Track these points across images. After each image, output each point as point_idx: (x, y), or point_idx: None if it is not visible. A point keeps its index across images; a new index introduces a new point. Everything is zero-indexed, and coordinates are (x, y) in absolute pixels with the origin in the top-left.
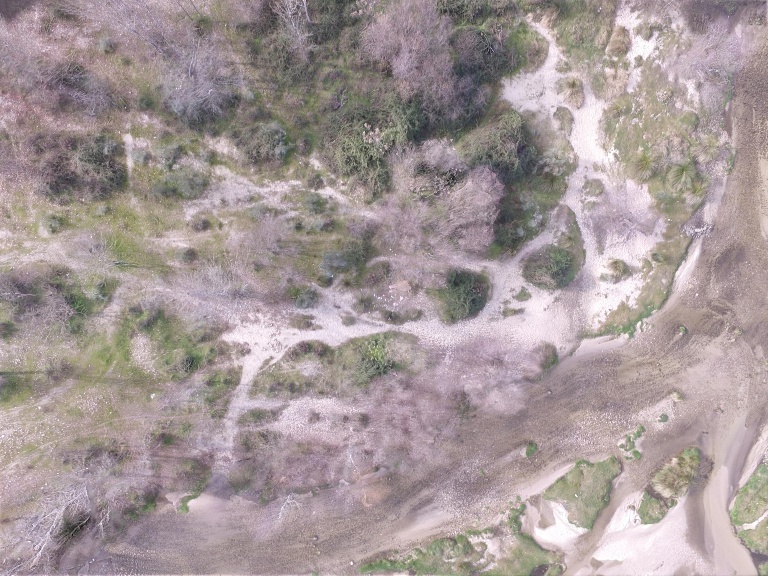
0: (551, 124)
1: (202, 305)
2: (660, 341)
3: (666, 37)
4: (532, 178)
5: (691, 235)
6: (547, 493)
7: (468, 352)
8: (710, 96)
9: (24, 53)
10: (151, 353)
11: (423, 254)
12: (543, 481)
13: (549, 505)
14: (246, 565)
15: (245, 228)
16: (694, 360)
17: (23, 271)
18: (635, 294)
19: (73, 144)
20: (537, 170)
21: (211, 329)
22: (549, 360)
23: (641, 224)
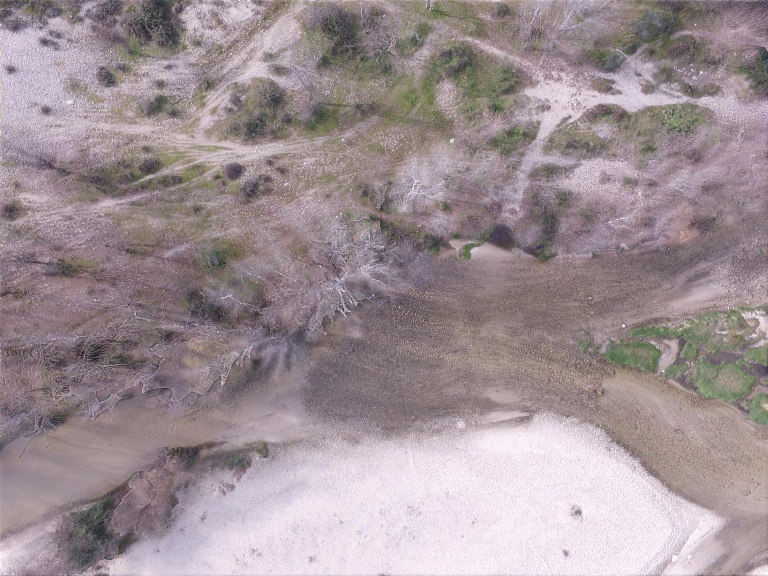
0: None
1: (508, 59)
2: None
3: None
4: None
5: None
6: None
7: (760, 132)
8: None
9: None
10: (456, 99)
11: None
12: None
13: None
14: (520, 317)
15: None
16: None
17: (342, 8)
18: None
19: None
20: None
21: (516, 82)
22: None
23: None
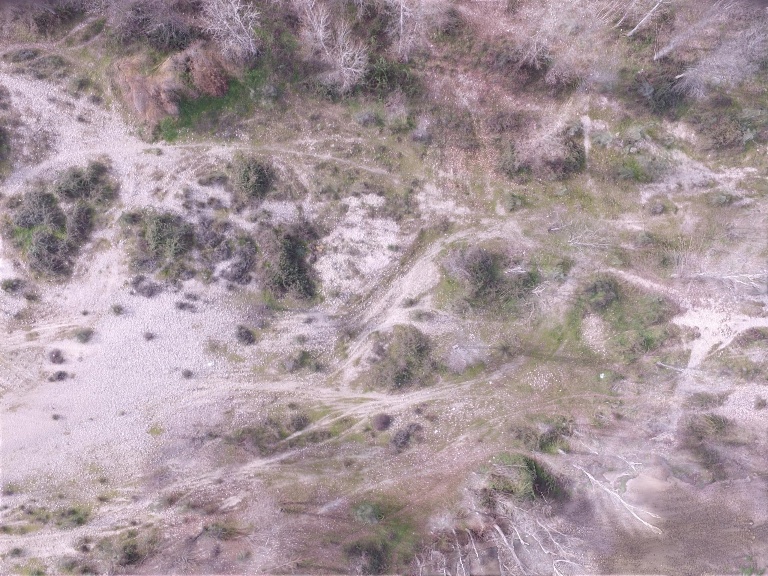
0: None
1: (654, 288)
2: None
3: None
4: None
5: None
6: None
7: None
8: None
9: (487, 32)
10: (603, 333)
11: None
12: None
13: None
14: (681, 546)
15: (700, 213)
16: None
17: (481, 247)
18: None
19: (537, 124)
20: None
21: (664, 312)
22: None
23: None
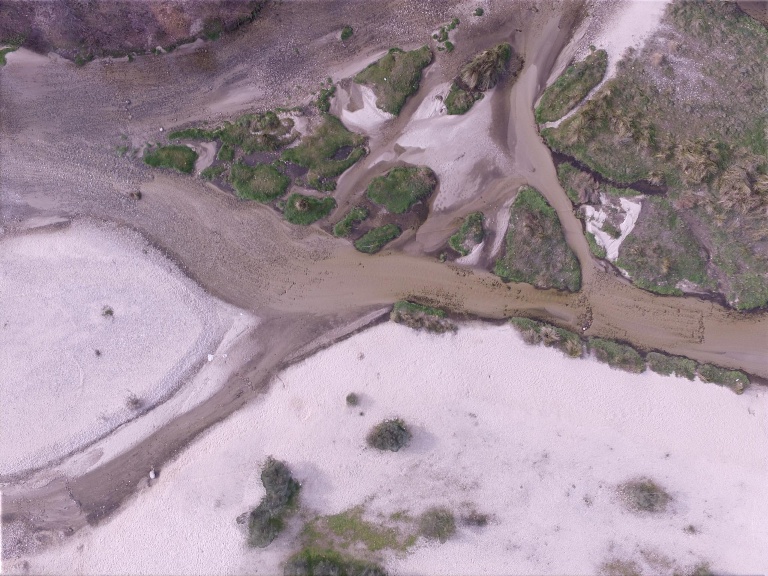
0: None
1: None
2: None
3: None
4: None
5: None
6: (358, 76)
7: None
8: None
9: None
10: None
11: None
12: (355, 65)
13: (359, 89)
14: (58, 122)
15: None
16: None
17: None
18: None
19: None
20: None
21: None
22: None
23: None
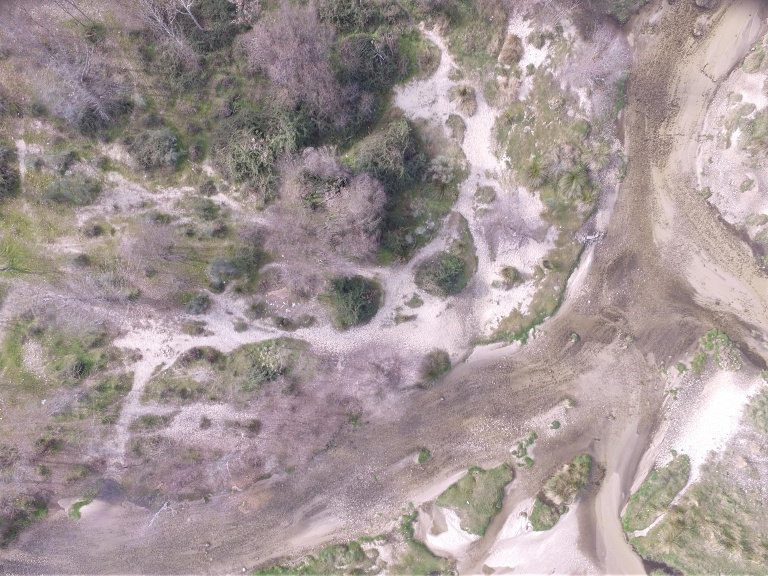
0: (443, 131)
1: (94, 311)
2: (552, 348)
3: (558, 46)
4: (423, 185)
5: (583, 242)
6: (439, 500)
7: (360, 358)
8: (602, 104)
9: None
10: (42, 359)
11: (315, 261)
12: (436, 488)
13: (441, 512)
14: (138, 572)
15: (137, 234)
16: (586, 367)
17: None
18: (527, 301)
19: None
20: (427, 177)
21: (102, 335)
22: (441, 367)
23: (533, 231)
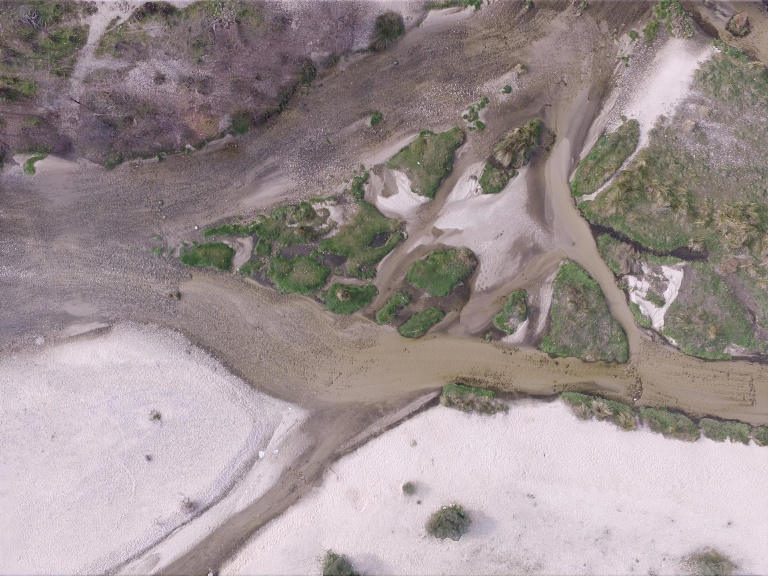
0: None
1: None
2: (506, 14)
3: None
4: None
5: None
6: (390, 161)
7: (315, 19)
8: None
9: None
10: None
11: None
12: (387, 151)
13: (392, 174)
14: (92, 227)
15: None
16: (540, 34)
17: None
18: None
19: None
20: None
21: None
22: (394, 27)
23: None
